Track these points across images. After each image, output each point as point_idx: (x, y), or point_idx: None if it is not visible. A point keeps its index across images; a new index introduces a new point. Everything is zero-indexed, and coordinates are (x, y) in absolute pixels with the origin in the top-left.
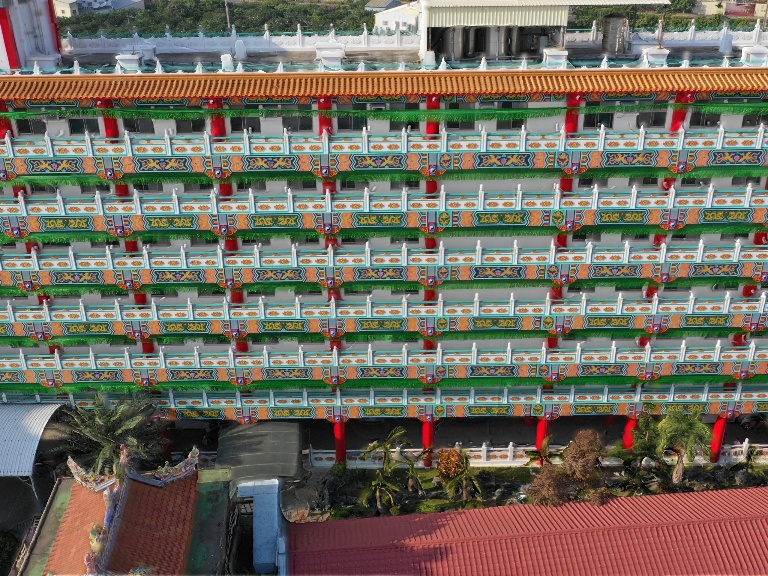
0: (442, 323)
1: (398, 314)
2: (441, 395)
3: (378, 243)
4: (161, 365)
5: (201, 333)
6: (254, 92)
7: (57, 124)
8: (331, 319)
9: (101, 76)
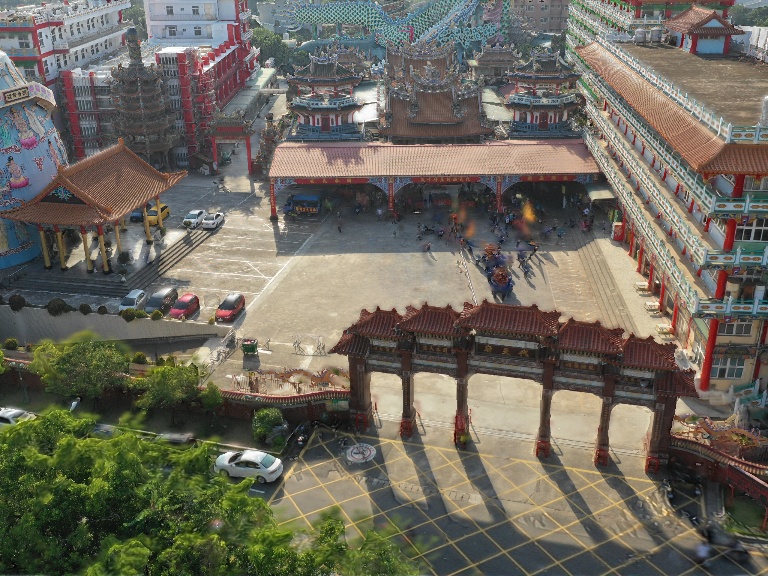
0: None
1: None
2: None
3: None
4: None
5: None
6: None
7: None
8: None
9: None
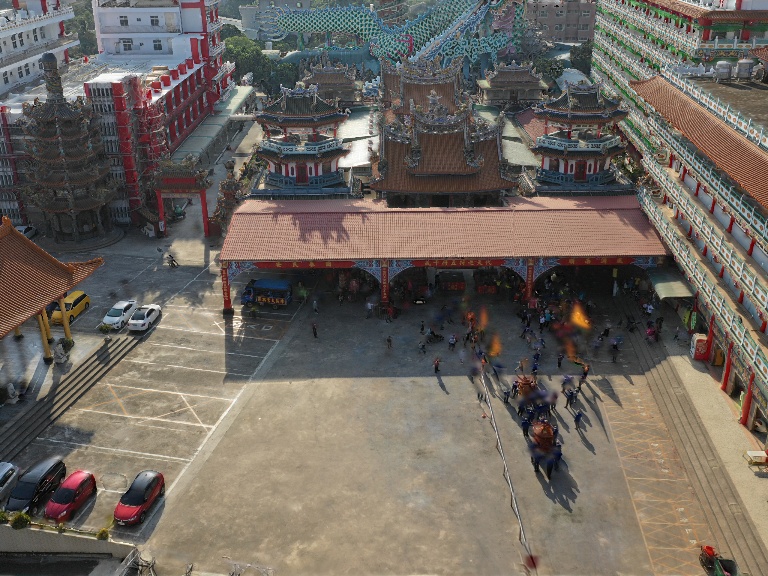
0: None
1: None
2: None
3: None
4: None
5: None
6: None
7: None
8: None
9: None
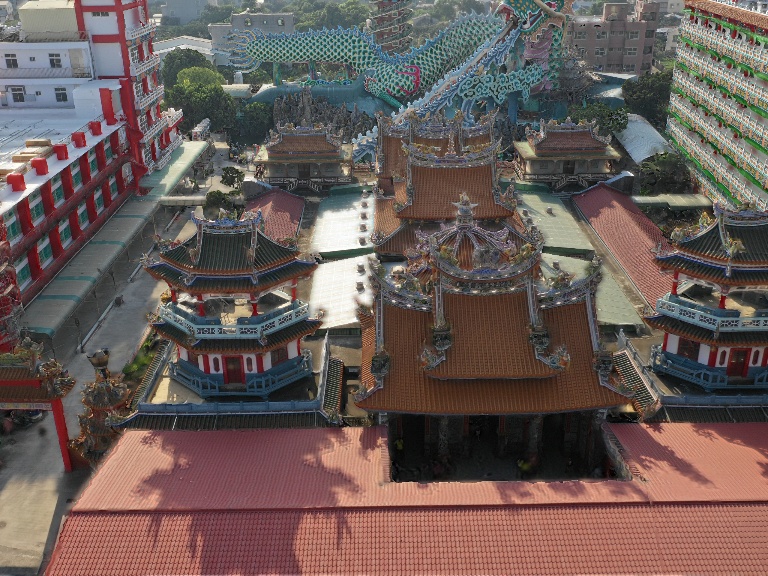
0: None
1: None
2: None
3: None
4: None
5: None
6: None
7: None
8: None
9: None
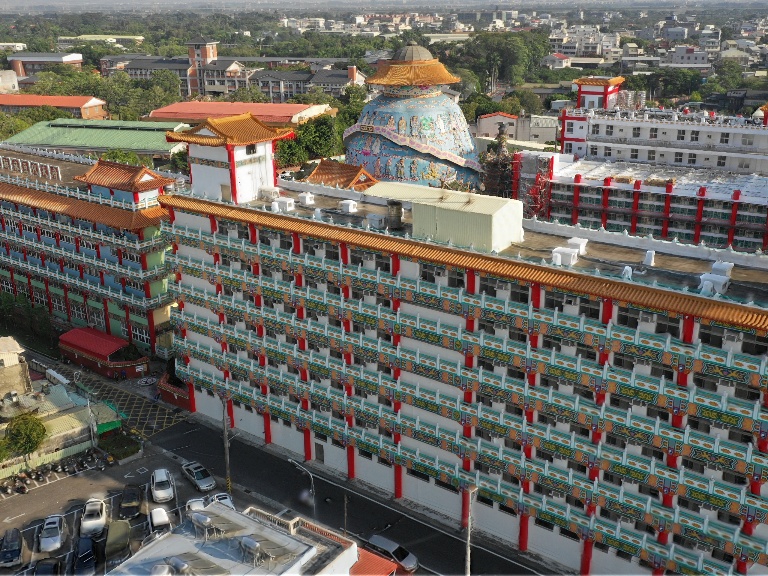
0: None
1: None
2: None
3: None
4: None
5: None
6: None
7: None
8: None
9: None
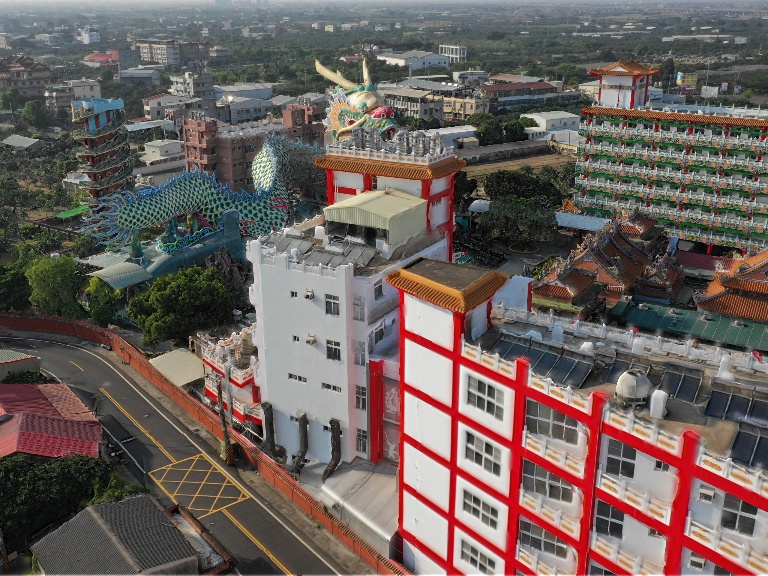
0: (755, 209)
1: (739, 203)
2: (751, 241)
3: (737, 177)
4: (651, 210)
5: (668, 200)
6: (704, 120)
7: (641, 125)
8: (714, 202)
9: (658, 112)
